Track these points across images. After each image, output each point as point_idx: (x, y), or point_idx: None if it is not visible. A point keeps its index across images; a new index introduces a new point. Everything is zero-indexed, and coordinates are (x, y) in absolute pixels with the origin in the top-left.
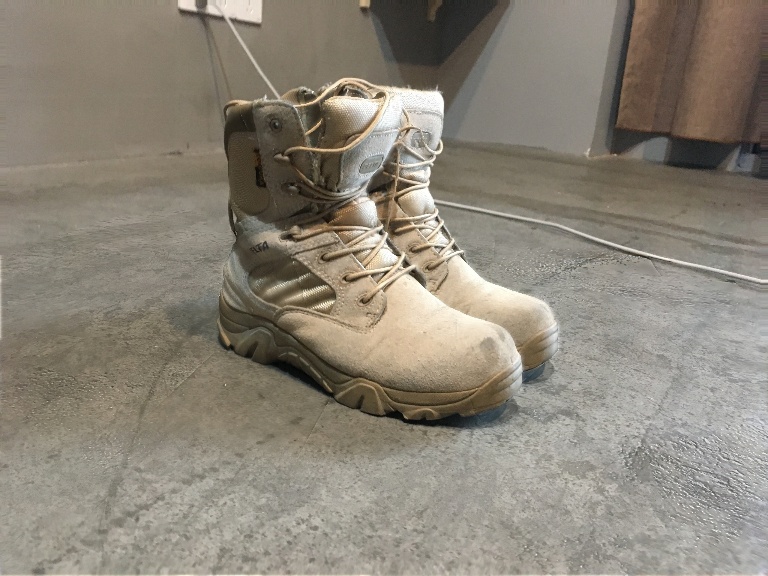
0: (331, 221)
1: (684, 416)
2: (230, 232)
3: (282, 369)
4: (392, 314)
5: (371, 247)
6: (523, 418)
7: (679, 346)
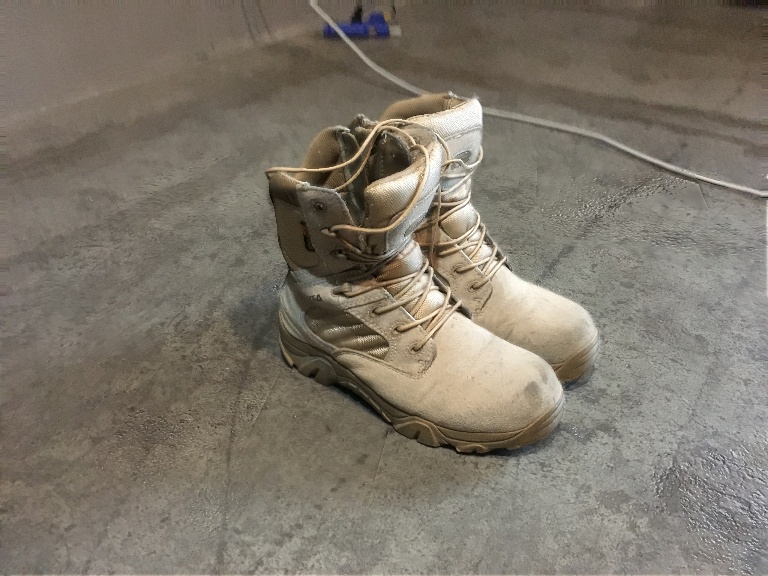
0: (379, 276)
1: (715, 422)
2: None
3: (343, 391)
4: (442, 359)
5: (418, 295)
6: (564, 438)
7: (718, 320)
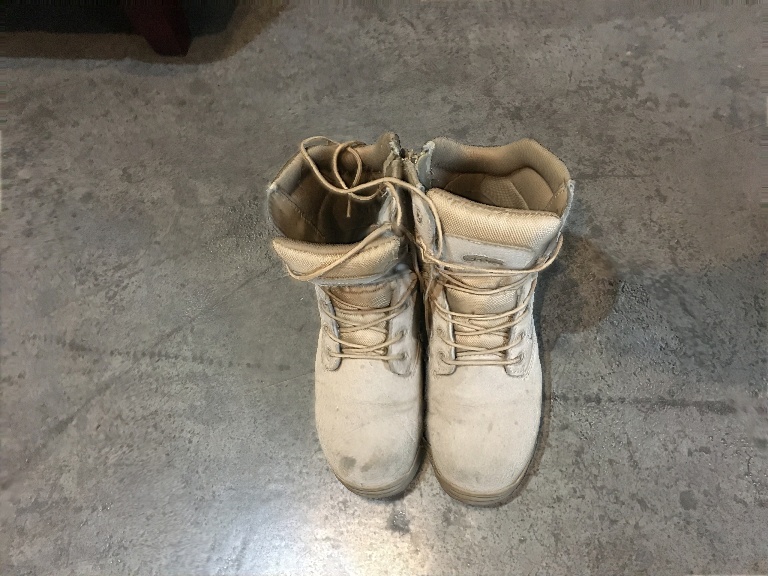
0: None
1: None
2: (615, 61)
3: None
4: (338, 377)
5: (352, 324)
6: (384, 509)
7: None
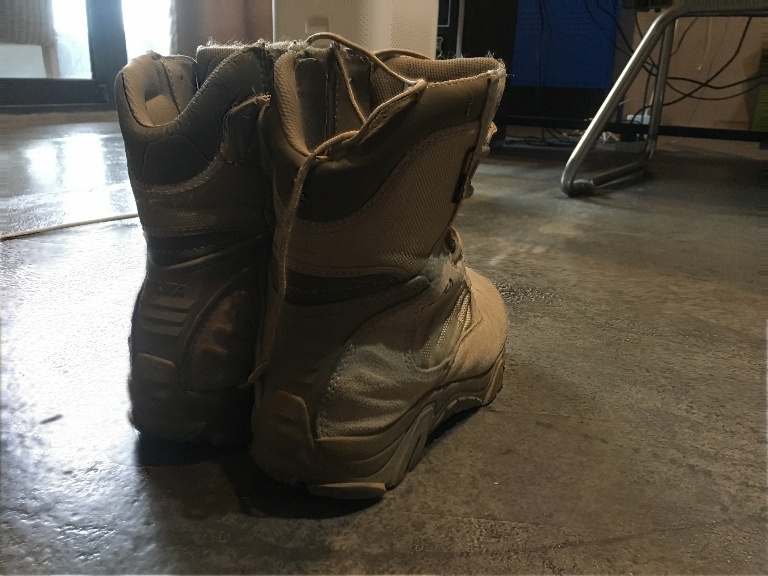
0: None
1: None
2: None
3: None
4: None
5: None
6: None
7: None
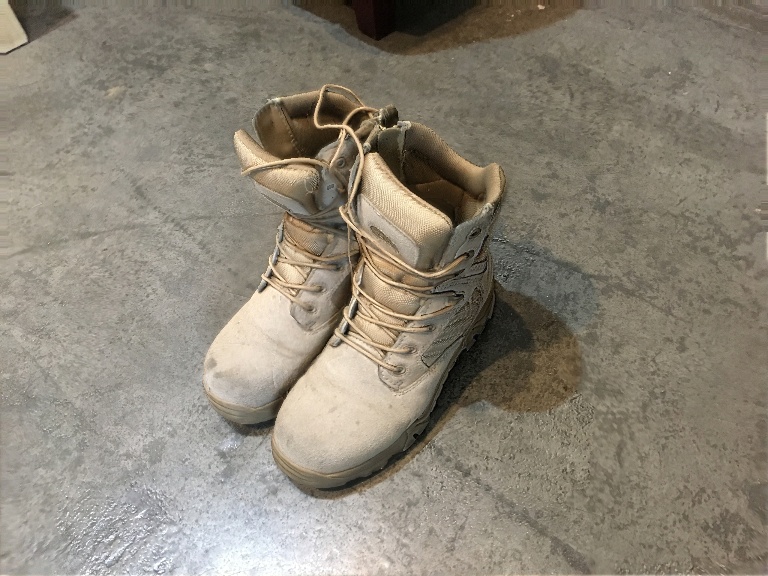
0: None
1: None
2: (738, 210)
3: None
4: None
5: None
6: (226, 433)
7: None
